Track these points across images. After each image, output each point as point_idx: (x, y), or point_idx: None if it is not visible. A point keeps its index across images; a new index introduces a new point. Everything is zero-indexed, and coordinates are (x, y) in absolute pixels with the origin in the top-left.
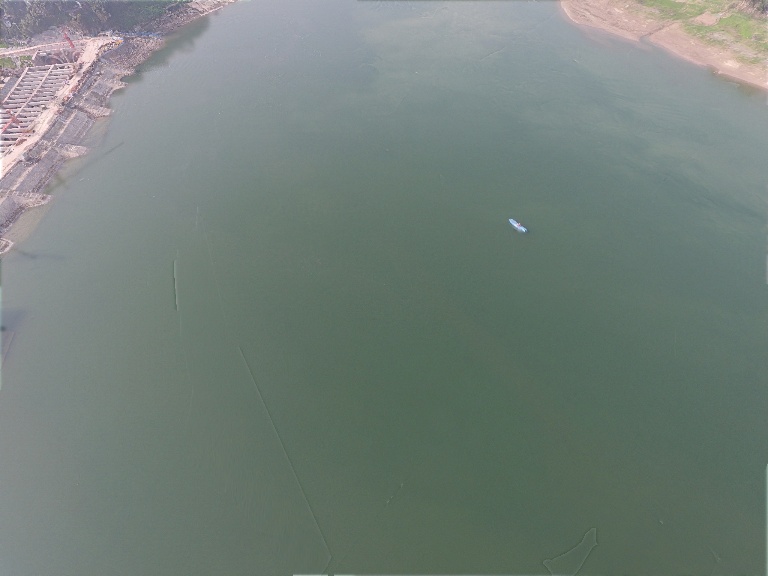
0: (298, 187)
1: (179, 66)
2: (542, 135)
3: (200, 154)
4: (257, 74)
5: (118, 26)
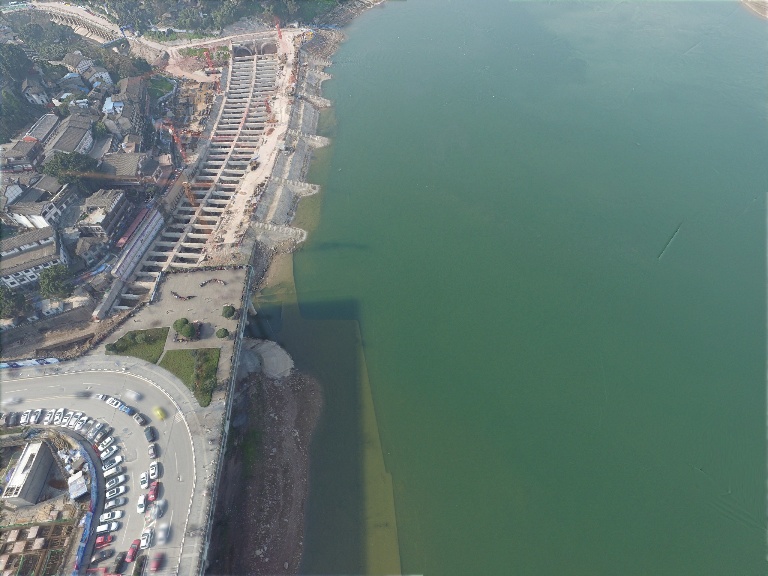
0: (569, 180)
1: (375, 58)
2: None
3: (447, 146)
4: (460, 67)
5: (302, 18)
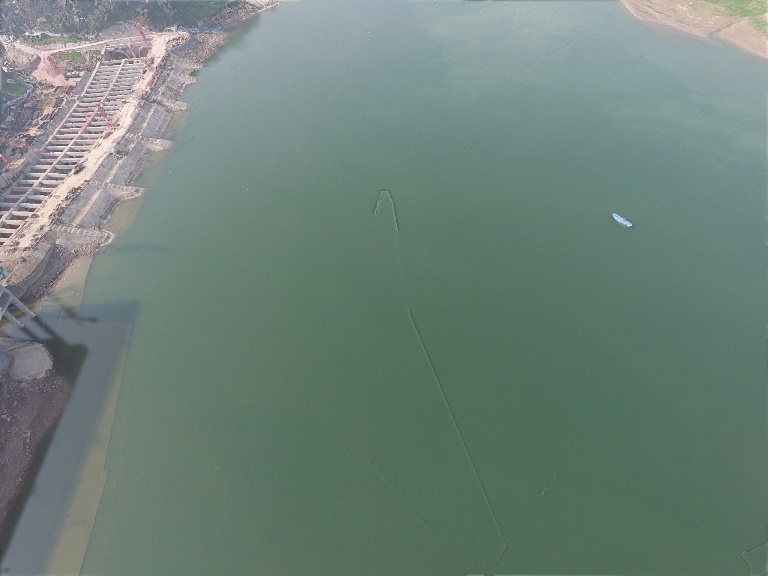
0: (389, 181)
1: (247, 61)
2: (626, 131)
3: (284, 148)
4: (326, 69)
5: (182, 21)
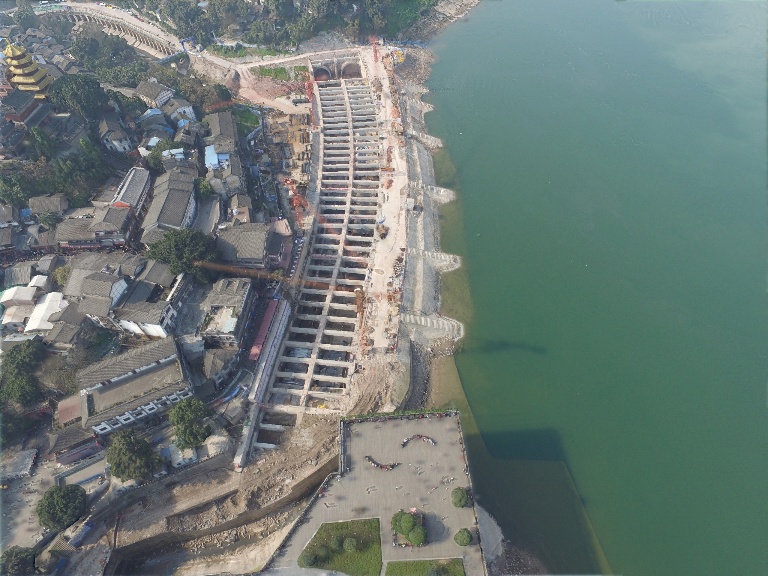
0: (759, 257)
1: (477, 85)
2: None
3: (597, 205)
4: (579, 100)
5: (387, 33)
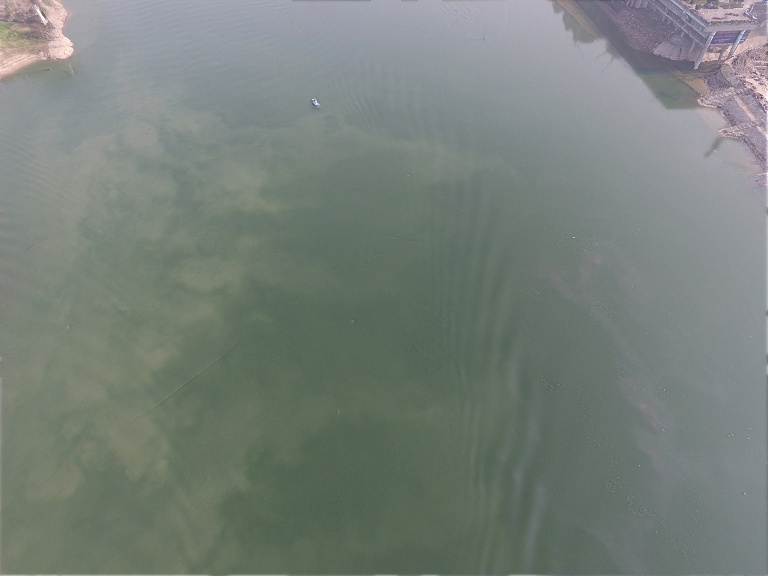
0: (491, 138)
1: None
2: (237, 186)
3: (615, 174)
4: (645, 327)
5: None
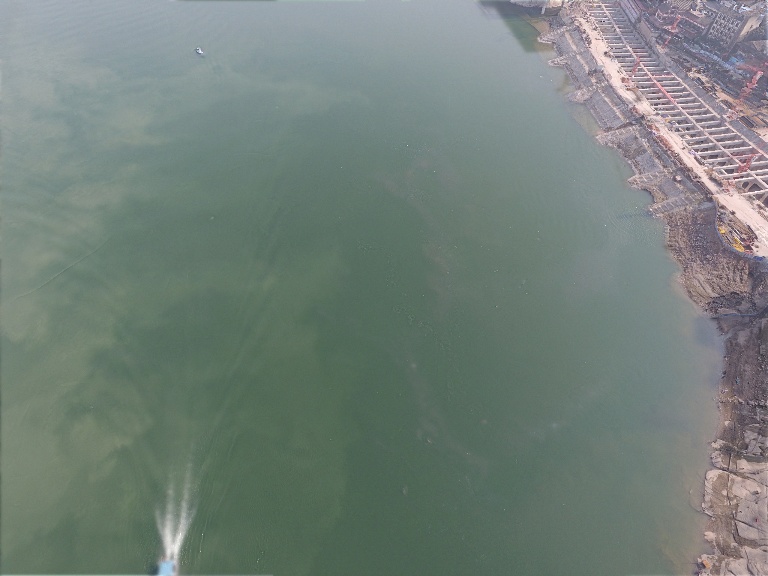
0: (354, 74)
1: (588, 223)
2: (121, 122)
3: (454, 98)
4: (451, 206)
5: None
